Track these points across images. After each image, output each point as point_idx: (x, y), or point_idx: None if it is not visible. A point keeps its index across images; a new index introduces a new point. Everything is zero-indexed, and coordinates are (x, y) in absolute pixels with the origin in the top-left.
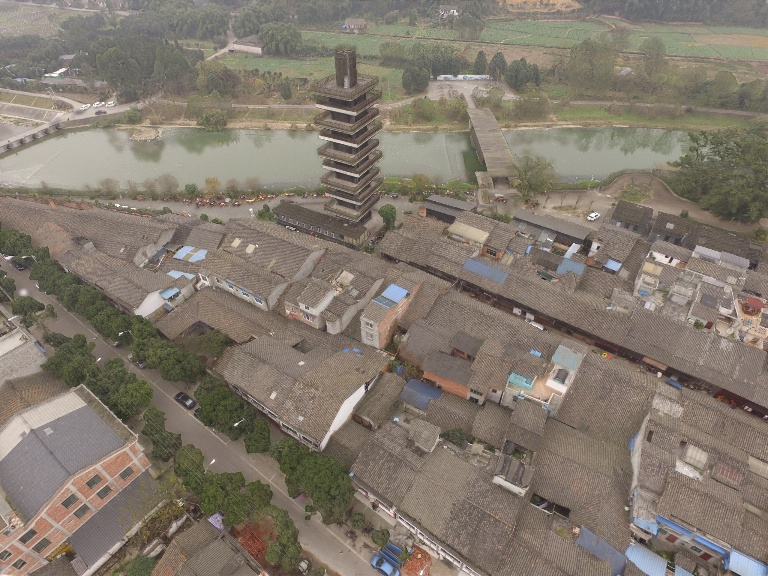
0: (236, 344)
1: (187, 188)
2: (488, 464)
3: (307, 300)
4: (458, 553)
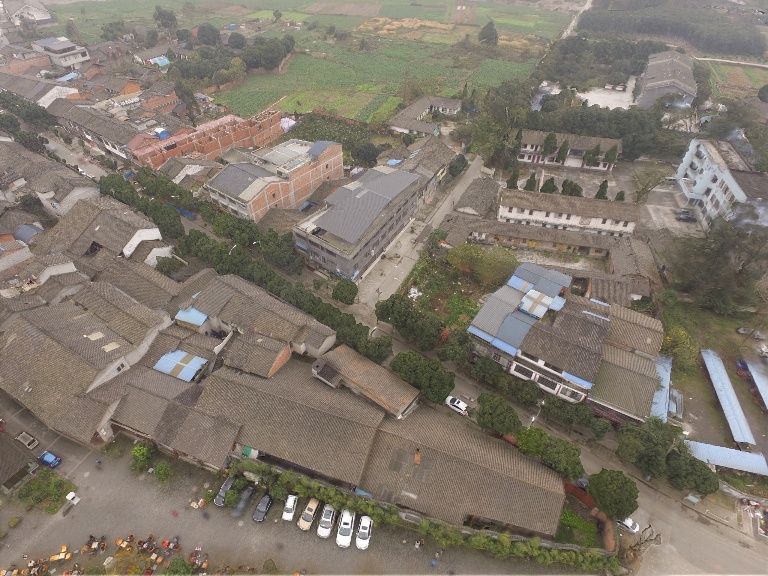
0: (147, 255)
1: (182, 560)
2: (22, 189)
3: (63, 258)
4: (67, 166)
